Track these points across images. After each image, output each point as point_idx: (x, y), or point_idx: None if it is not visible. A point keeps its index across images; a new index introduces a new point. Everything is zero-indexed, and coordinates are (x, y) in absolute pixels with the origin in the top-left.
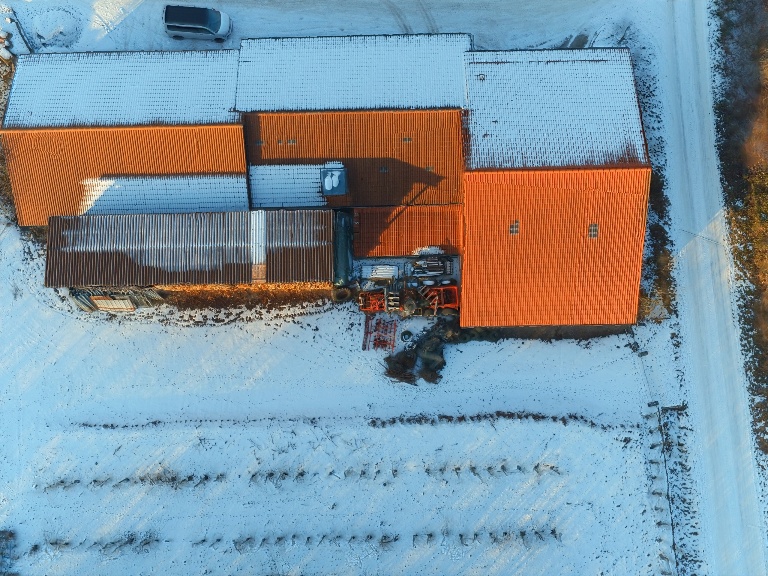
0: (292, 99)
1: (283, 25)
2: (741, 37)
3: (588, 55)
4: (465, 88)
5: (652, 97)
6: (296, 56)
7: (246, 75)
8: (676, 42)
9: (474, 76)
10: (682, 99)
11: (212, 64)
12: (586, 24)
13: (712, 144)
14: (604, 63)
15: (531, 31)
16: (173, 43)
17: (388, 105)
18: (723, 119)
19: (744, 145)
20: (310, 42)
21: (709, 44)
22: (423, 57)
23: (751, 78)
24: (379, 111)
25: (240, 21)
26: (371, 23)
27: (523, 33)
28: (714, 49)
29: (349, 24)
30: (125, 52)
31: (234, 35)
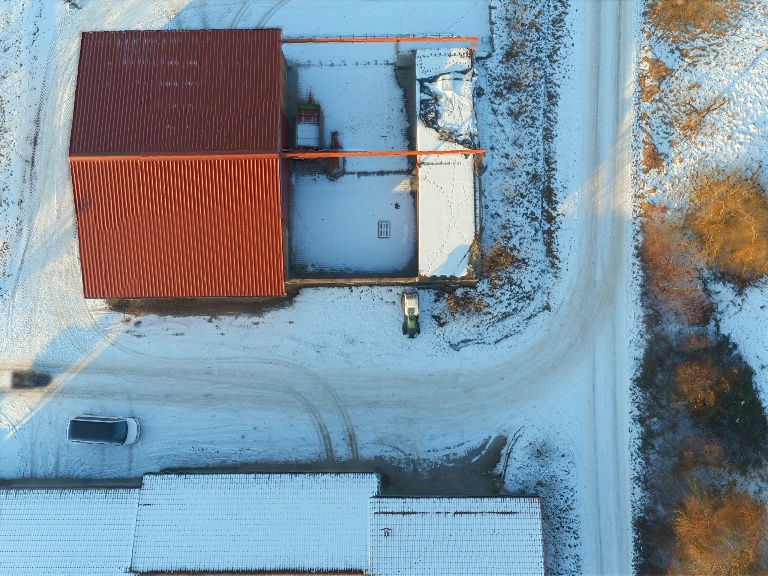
0: (190, 556)
1: (194, 423)
2: (662, 447)
3: (497, 505)
4: (368, 546)
5: (569, 511)
6: (198, 499)
7: (145, 523)
8: (596, 448)
9: (378, 530)
10: (600, 512)
11: (111, 508)
12: (505, 425)
13: (629, 563)
14: (512, 516)
15: (449, 431)
16: (80, 444)
17: (288, 567)
18: (641, 537)
19: (661, 567)
20: (213, 480)
21: (629, 453)
22: (328, 503)
23: (671, 493)
24: (278, 575)
25: (150, 420)
26: (285, 421)
27: (440, 433)
28: (634, 458)
29: (262, 422)
30: (22, 490)
31: (143, 436)
